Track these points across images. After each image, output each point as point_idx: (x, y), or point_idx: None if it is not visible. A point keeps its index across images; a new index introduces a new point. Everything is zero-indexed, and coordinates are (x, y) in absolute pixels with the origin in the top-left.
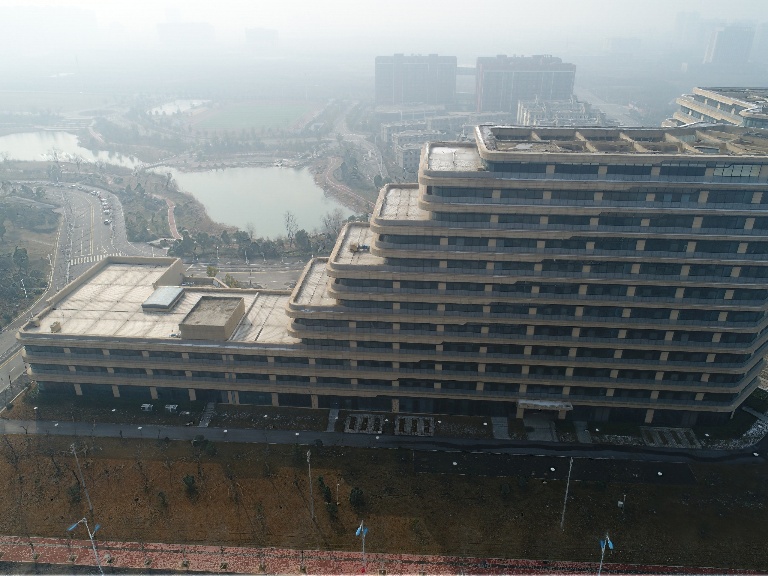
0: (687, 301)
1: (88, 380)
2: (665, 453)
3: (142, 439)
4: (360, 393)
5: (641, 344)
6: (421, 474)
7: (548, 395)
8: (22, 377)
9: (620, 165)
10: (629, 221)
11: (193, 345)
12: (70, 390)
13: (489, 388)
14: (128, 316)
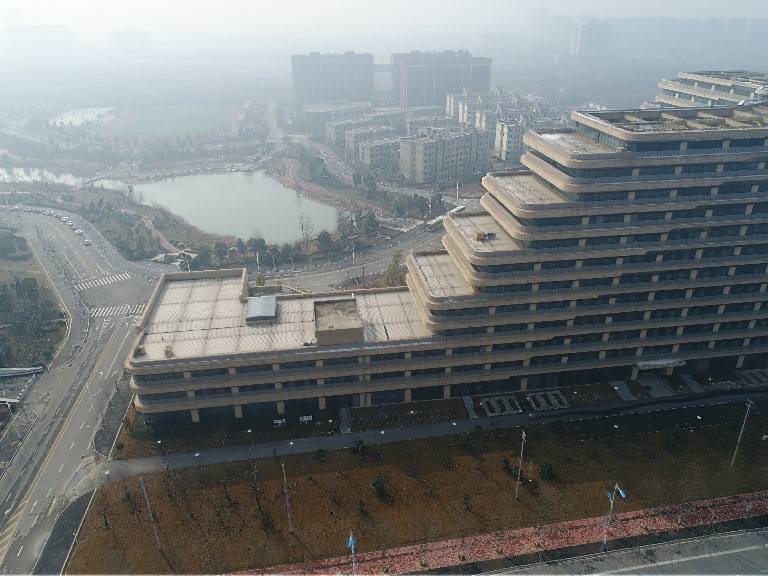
0: None
1: (210, 404)
2: (767, 391)
3: (293, 455)
4: (494, 377)
5: (741, 298)
6: (584, 442)
7: (660, 355)
8: (109, 414)
9: (740, 139)
10: (742, 188)
11: (330, 351)
12: (185, 418)
13: (610, 355)
14: (236, 331)
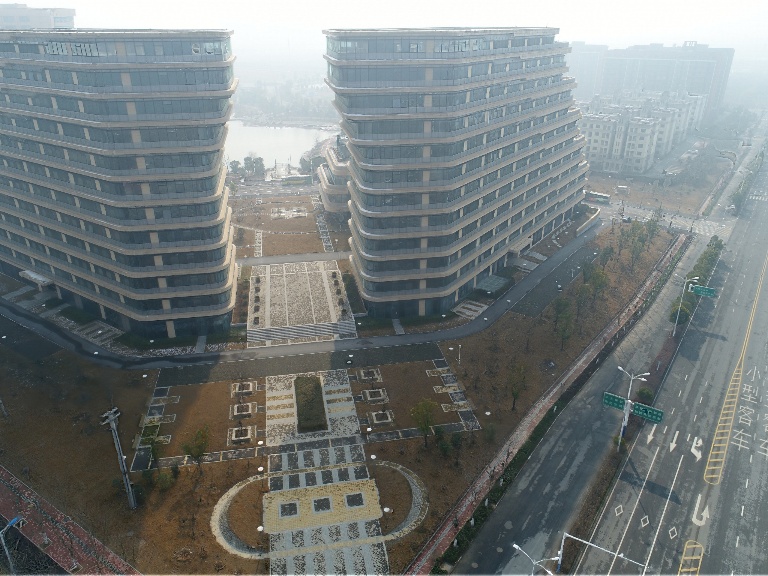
0: (78, 188)
1: None
2: (68, 339)
3: None
4: None
5: (69, 230)
6: None
7: (45, 271)
8: None
9: (1, 43)
10: (23, 99)
11: None
12: None
13: (18, 256)
14: None
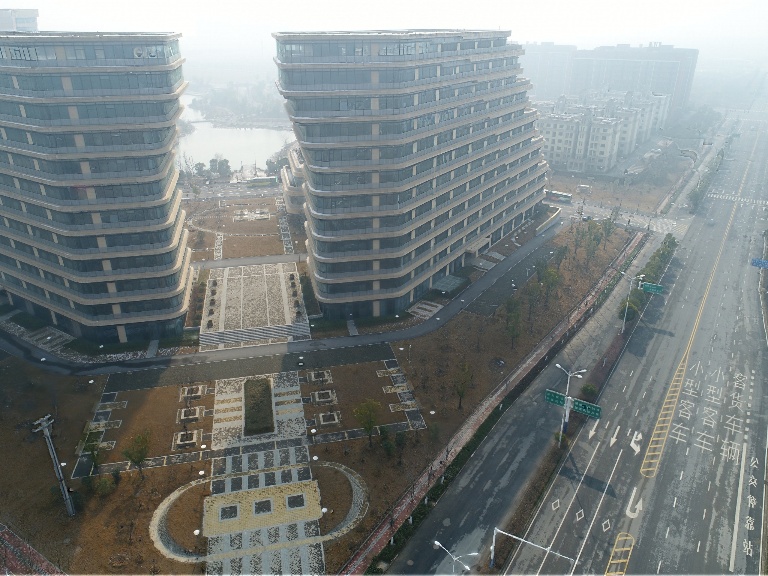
0: None
1: None
2: (18, 345)
3: None
4: None
5: (17, 235)
6: None
7: None
8: None
9: None
10: None
11: None
12: None
13: None
14: None
